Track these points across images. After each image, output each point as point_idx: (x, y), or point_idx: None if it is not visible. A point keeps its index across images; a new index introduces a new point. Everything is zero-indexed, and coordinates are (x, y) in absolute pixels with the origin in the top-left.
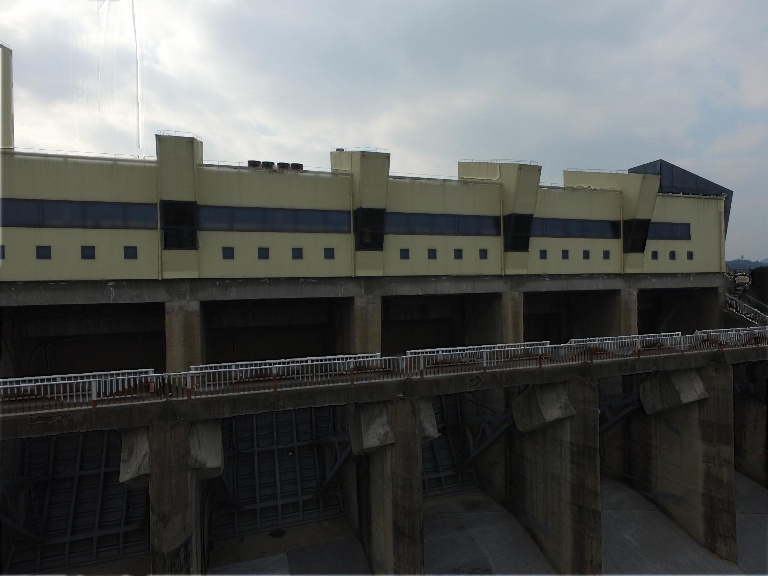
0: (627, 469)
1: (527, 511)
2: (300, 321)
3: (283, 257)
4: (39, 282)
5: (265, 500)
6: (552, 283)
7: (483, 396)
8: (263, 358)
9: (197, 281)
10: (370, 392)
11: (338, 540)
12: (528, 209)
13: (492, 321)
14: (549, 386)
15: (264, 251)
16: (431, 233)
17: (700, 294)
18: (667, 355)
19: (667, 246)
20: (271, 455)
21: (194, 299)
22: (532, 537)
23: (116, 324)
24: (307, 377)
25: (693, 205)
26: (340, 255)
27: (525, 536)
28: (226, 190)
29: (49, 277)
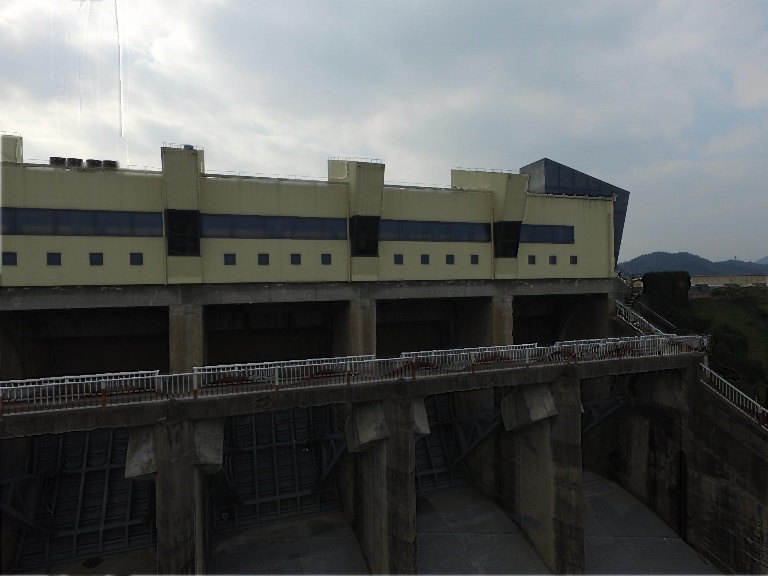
0: (498, 488)
1: (365, 537)
2: (144, 330)
3: (79, 263)
4: None
5: (87, 525)
6: (411, 290)
7: (342, 410)
8: (113, 369)
9: None
10: (126, 416)
11: (152, 570)
12: (373, 211)
13: (345, 331)
14: (368, 404)
15: (55, 256)
16: (263, 236)
17: (593, 300)
18: (508, 369)
19: (547, 250)
20: (102, 475)
21: None
22: (367, 566)
23: None
24: (44, 400)
25: (577, 206)
26: (150, 261)
27: (361, 565)
28: (7, 189)
29: None
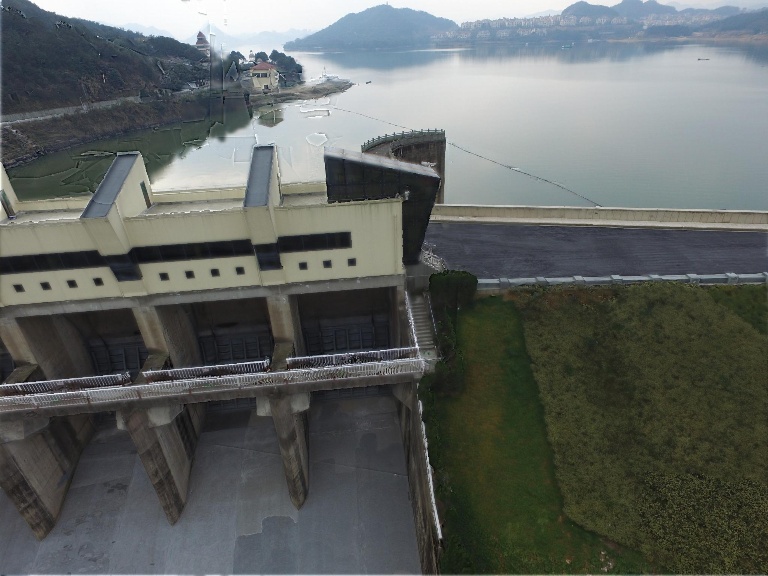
0: None
1: None
2: None
3: None
4: None
5: None
6: (184, 297)
7: None
8: None
9: None
10: None
11: None
12: (117, 251)
13: None
14: None
15: None
16: (38, 270)
17: None
18: (222, 390)
19: (320, 256)
20: None
21: None
22: None
23: None
24: None
25: (354, 213)
26: None
27: None
28: None
29: None
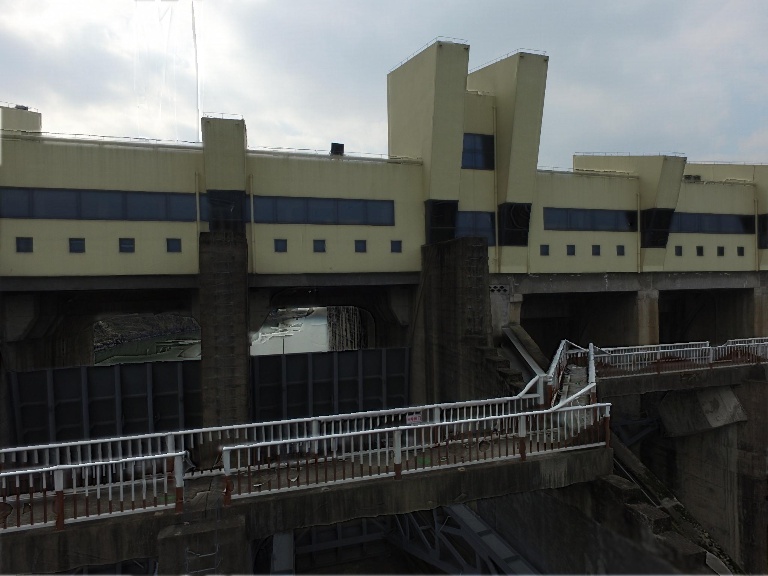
0: None
1: None
2: None
3: (712, 254)
4: (566, 274)
5: None
6: None
7: None
8: None
9: (657, 274)
10: None
11: None
12: None
13: None
14: None
15: (699, 249)
16: None
17: None
18: None
19: None
20: None
21: (655, 289)
22: None
23: (529, 311)
24: None
25: None
26: (747, 252)
27: None
28: None
29: (574, 270)
